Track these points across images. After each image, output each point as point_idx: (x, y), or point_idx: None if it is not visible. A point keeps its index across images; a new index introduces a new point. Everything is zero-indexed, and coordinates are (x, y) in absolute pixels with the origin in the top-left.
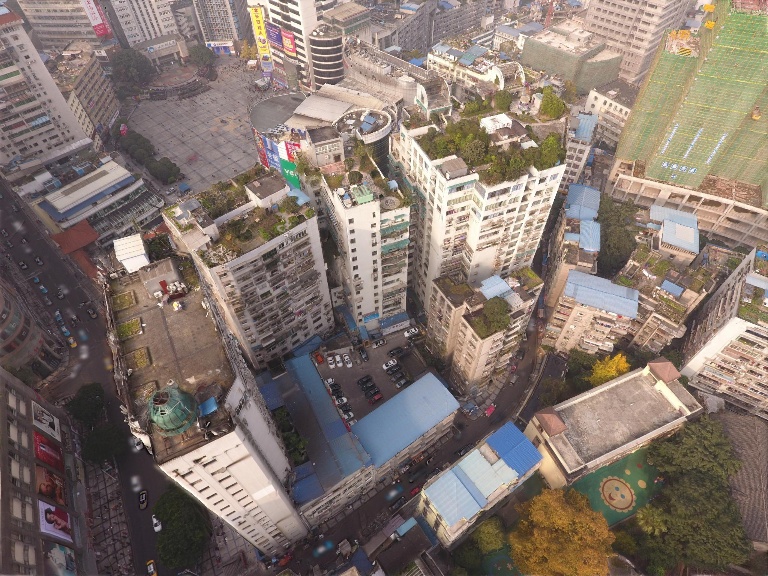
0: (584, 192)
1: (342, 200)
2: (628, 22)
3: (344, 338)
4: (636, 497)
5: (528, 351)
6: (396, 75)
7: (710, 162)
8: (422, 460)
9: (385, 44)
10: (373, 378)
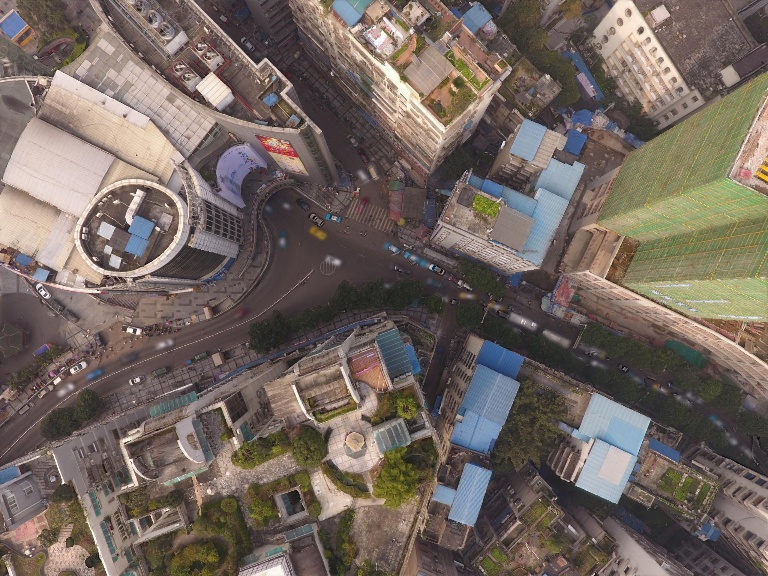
0: (494, 386)
1: None
2: None
3: None
4: None
5: None
6: (191, 75)
7: (723, 317)
8: None
9: None
10: None
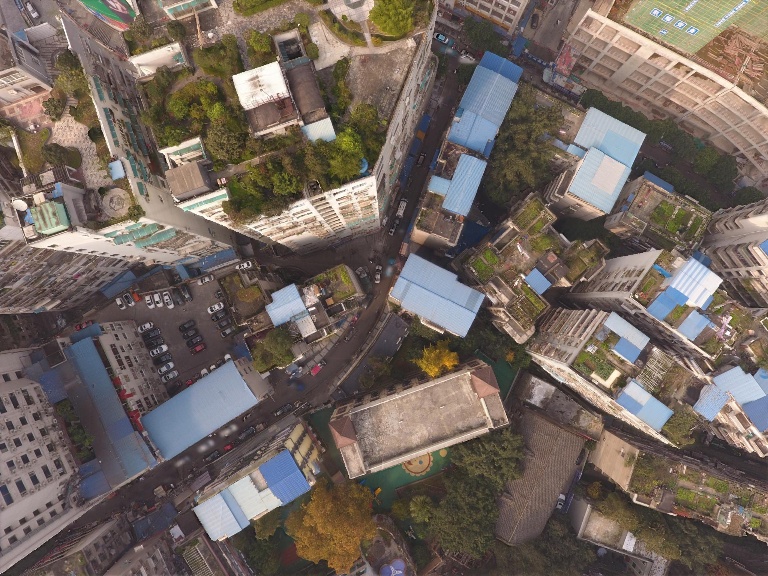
0: (492, 86)
1: (21, 226)
2: None
3: (160, 276)
4: (433, 464)
5: (378, 296)
6: None
7: (721, 25)
8: (239, 416)
9: None
10: (197, 323)
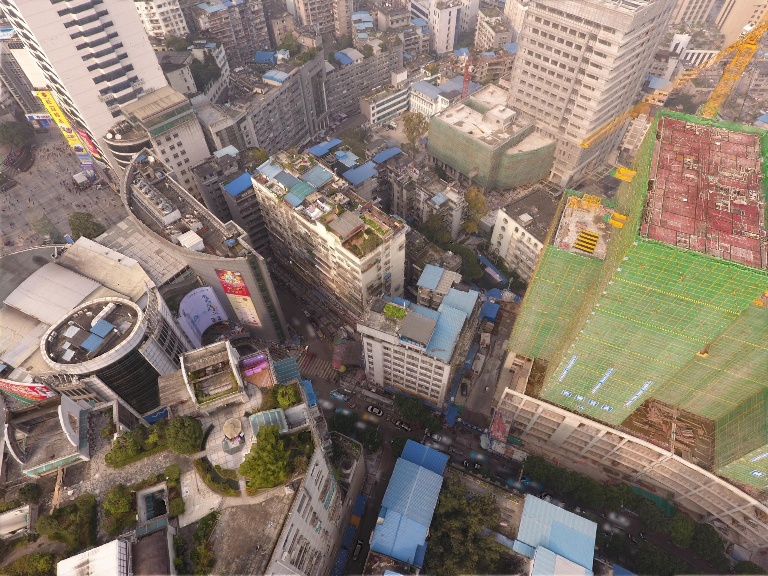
0: (415, 480)
1: None
2: (559, 103)
3: None
4: None
5: None
6: (176, 231)
7: (631, 405)
8: None
9: (228, 136)
10: None
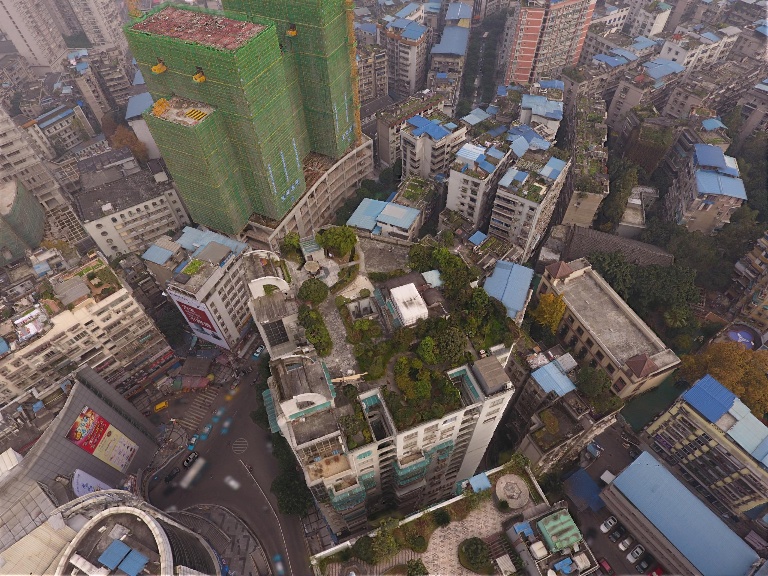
0: None
1: (579, 574)
2: None
3: None
4: None
5: None
6: None
7: (300, 166)
8: None
9: None
10: None
